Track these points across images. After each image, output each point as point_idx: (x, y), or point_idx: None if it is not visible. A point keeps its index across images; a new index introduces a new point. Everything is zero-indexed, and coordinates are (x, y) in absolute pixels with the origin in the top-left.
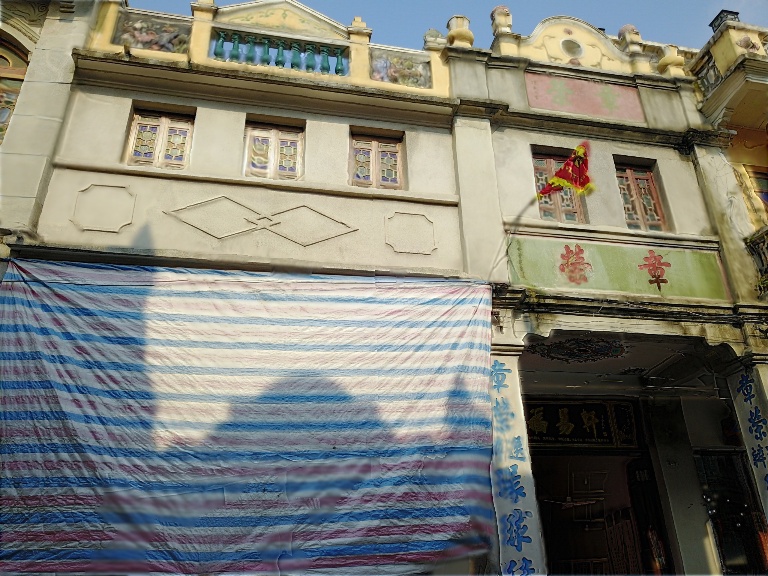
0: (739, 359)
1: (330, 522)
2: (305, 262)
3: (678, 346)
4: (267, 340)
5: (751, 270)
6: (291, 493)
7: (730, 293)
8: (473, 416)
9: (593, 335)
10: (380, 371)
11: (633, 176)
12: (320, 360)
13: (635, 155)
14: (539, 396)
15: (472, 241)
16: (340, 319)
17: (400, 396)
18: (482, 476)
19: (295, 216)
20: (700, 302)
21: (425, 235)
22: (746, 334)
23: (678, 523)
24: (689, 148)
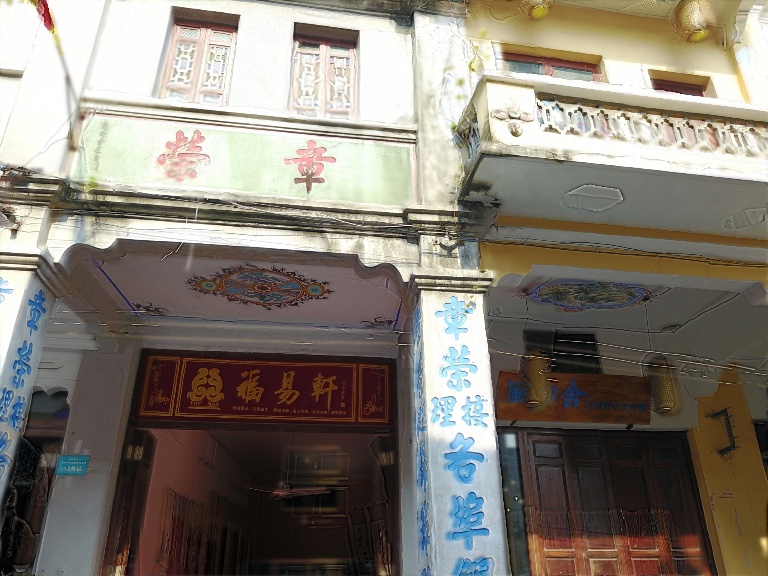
0: (408, 286)
1: None
2: None
3: (342, 272)
4: None
5: (452, 167)
6: None
7: (416, 198)
8: None
9: (193, 251)
10: None
11: (328, 53)
12: None
13: (329, 24)
14: (251, 354)
15: (20, 118)
16: None
17: None
18: None
19: None
20: (363, 208)
21: None
22: (420, 251)
23: (407, 520)
24: (411, 17)
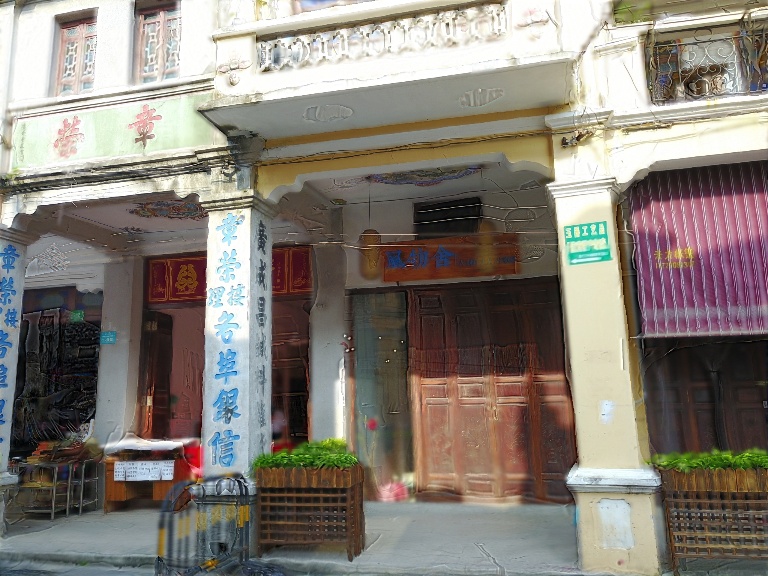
0: None
1: None
2: None
3: None
4: None
5: None
6: None
7: None
8: None
9: (84, 204)
10: None
11: (166, 18)
12: None
13: None
14: None
15: None
16: None
17: None
18: None
19: None
20: (176, 153)
21: None
22: None
23: (312, 362)
24: None
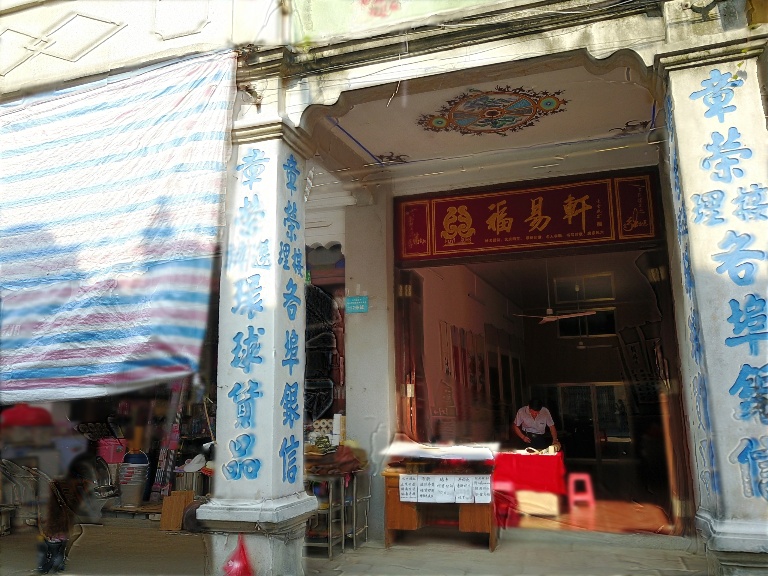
0: (653, 71)
1: (25, 347)
2: (50, 80)
3: (572, 73)
4: (11, 173)
5: None
6: (5, 321)
7: None
8: (187, 222)
9: (411, 87)
10: (105, 186)
11: None
12: (50, 185)
13: None
14: (494, 186)
15: None
16: (71, 136)
17: (115, 211)
18: (187, 291)
19: (69, 29)
20: None
21: (199, 8)
22: (665, 23)
23: (683, 335)
24: None
